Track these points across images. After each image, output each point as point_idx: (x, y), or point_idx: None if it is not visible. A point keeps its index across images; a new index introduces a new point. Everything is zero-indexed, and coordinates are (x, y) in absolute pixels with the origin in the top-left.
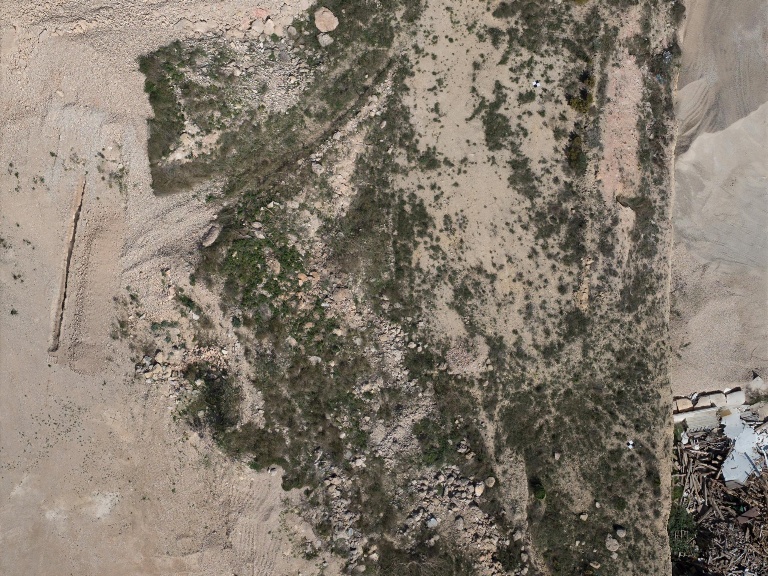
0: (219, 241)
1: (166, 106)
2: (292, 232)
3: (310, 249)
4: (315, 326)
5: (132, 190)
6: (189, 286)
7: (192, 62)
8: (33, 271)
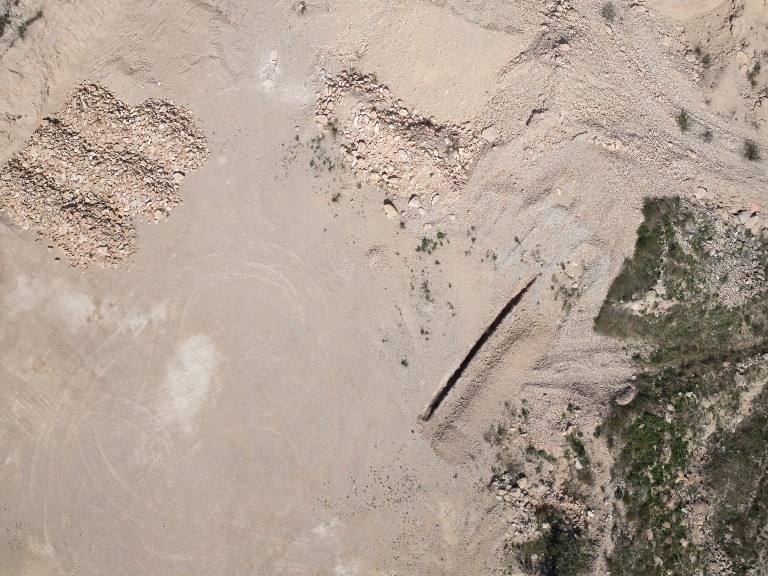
0: (633, 406)
1: (649, 256)
2: (692, 428)
3: (694, 450)
4: (670, 528)
5: (575, 314)
6: (591, 435)
7: (684, 224)
8: (442, 335)
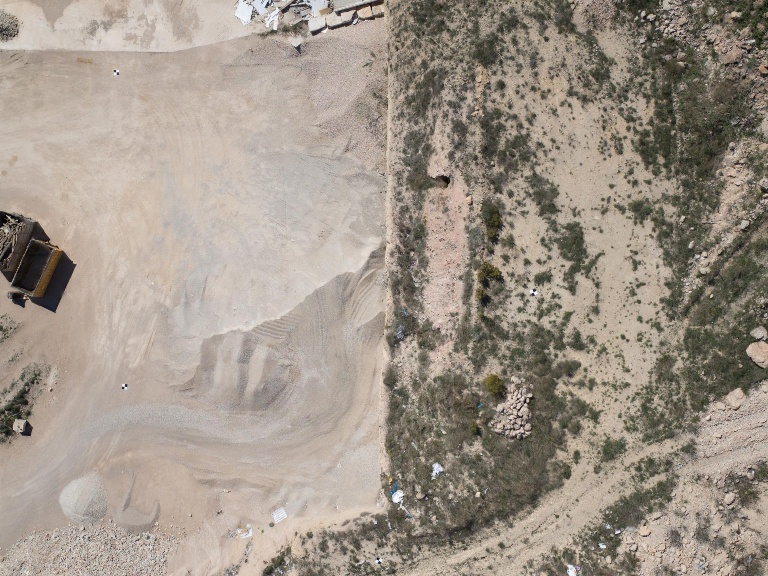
0: None
1: None
2: None
3: None
4: (763, 15)
5: None
6: None
7: None
8: None
